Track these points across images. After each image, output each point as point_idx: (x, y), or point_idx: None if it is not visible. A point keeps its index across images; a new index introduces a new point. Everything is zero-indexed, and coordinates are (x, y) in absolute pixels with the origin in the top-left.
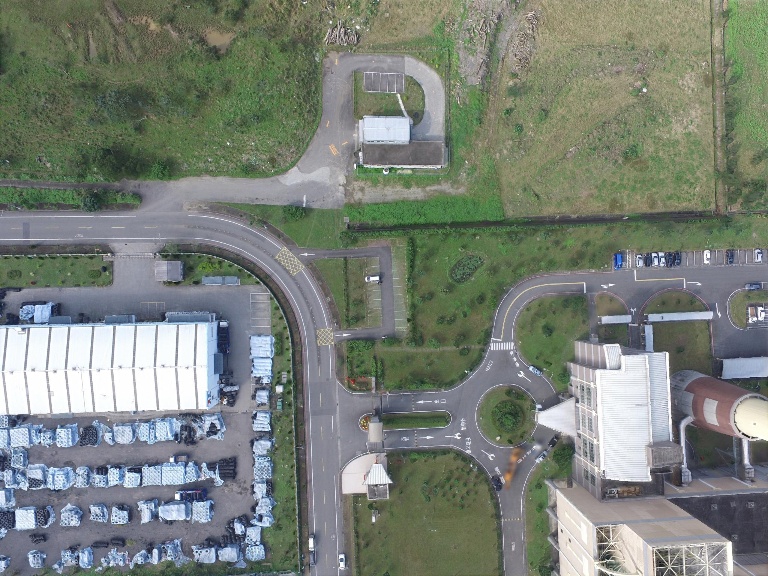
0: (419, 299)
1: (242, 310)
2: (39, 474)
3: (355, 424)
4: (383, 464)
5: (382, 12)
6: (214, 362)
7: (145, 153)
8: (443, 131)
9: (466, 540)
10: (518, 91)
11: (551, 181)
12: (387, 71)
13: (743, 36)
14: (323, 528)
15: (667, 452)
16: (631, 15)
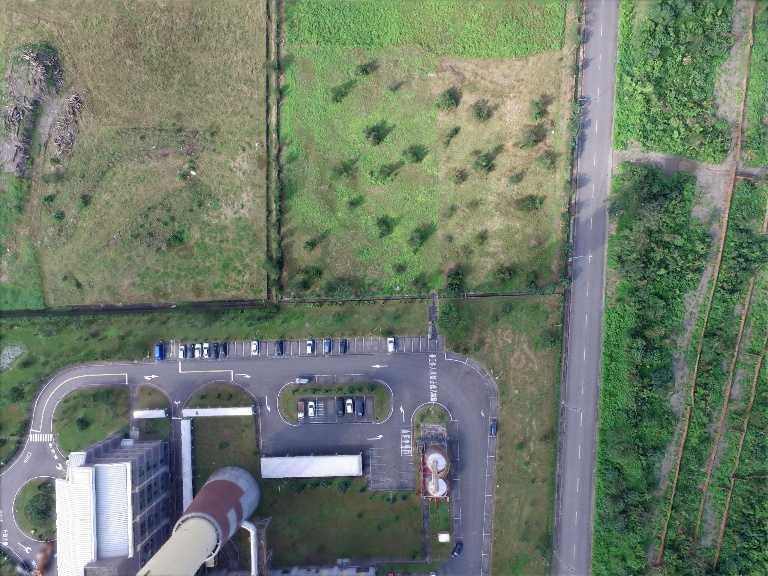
0: None
1: None
2: None
3: None
4: None
5: None
6: None
7: None
8: None
9: None
10: (49, 179)
11: (91, 269)
12: None
13: (301, 114)
14: None
15: (102, 572)
16: (180, 95)
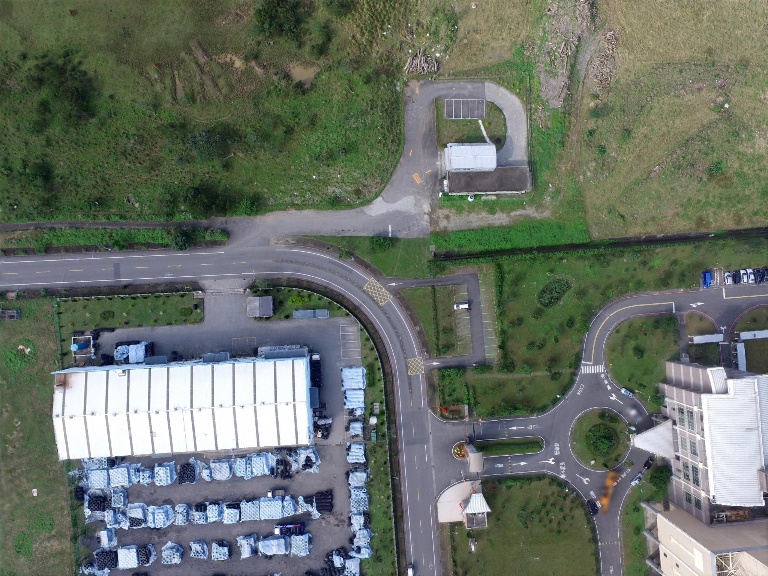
0: (509, 325)
1: (332, 342)
2: (139, 513)
3: (449, 452)
4: (478, 492)
5: (461, 38)
6: (310, 396)
7: (232, 190)
8: (526, 155)
9: (564, 565)
10: (601, 113)
11: (636, 201)
12: (468, 97)
13: None
14: (421, 558)
15: None
16: (710, 31)
